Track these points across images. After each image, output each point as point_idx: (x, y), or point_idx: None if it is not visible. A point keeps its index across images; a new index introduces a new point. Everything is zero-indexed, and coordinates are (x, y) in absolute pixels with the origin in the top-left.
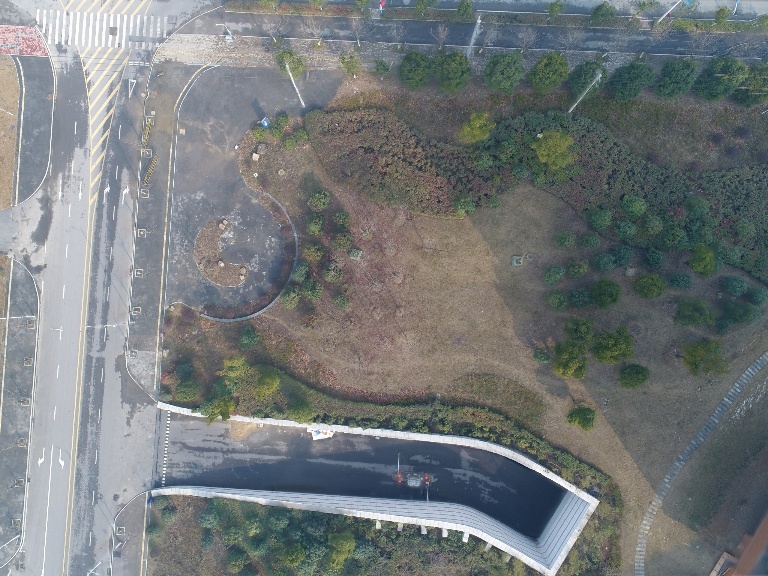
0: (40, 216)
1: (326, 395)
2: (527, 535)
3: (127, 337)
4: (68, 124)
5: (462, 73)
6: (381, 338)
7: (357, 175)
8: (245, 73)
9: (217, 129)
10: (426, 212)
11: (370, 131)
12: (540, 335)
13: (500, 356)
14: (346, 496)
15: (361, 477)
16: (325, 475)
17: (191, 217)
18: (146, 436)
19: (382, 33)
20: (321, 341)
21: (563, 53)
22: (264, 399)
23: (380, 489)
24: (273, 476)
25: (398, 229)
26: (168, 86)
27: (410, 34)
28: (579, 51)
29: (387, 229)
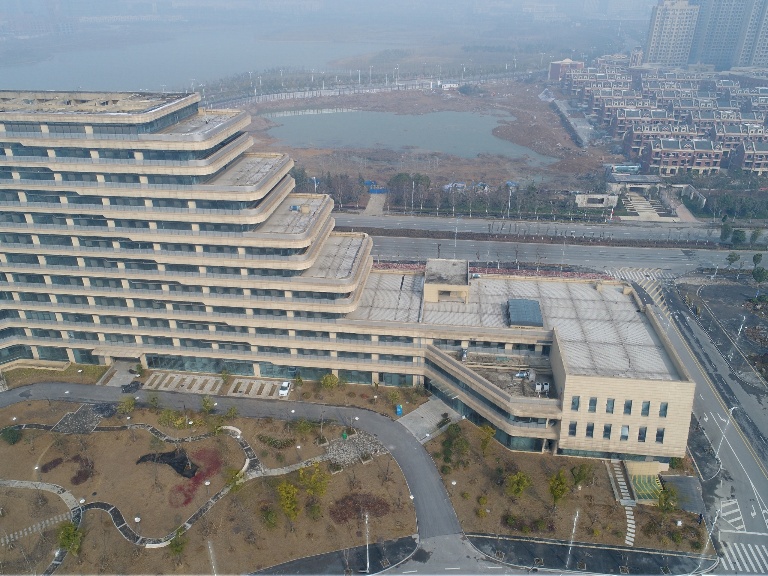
0: None
1: None
2: None
3: (729, 366)
4: None
5: None
6: None
7: None
8: None
9: None
10: None
11: None
12: None
13: None
14: None
15: None
16: None
17: None
18: None
19: None
20: None
21: None
22: None
23: None
24: None
25: None
26: None
27: None
28: None
29: None
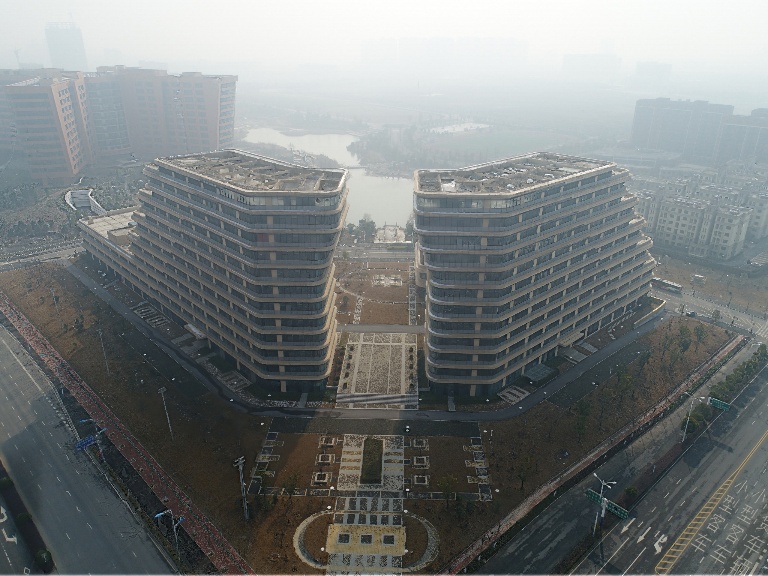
0: None
1: None
2: None
3: None
4: None
5: None
6: None
7: None
8: None
9: None
10: None
11: None
12: None
13: None
14: None
15: None
16: None
17: None
18: None
19: None
20: None
21: None
22: None
23: None
24: None
25: None
26: None
27: None
28: None
29: None
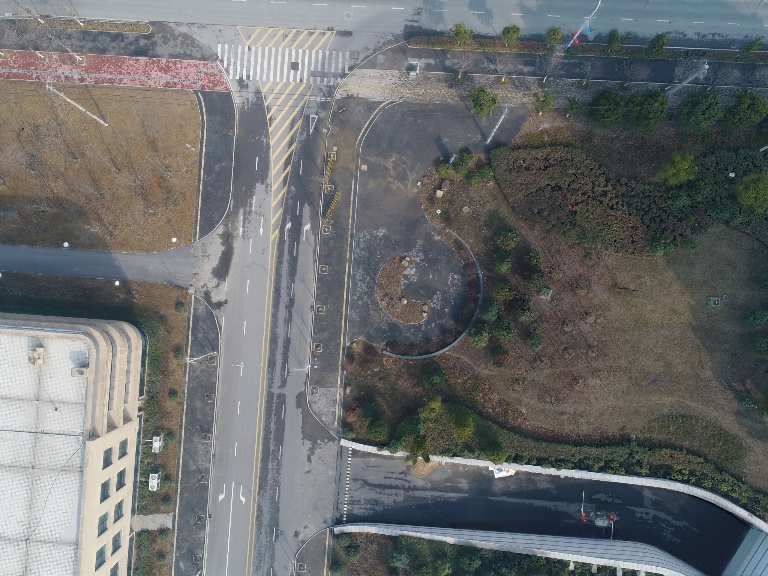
0: (221, 252)
1: (518, 435)
2: (709, 574)
3: (308, 373)
4: (249, 159)
5: (661, 113)
6: (573, 378)
7: (545, 213)
8: (428, 109)
9: (399, 165)
10: (620, 252)
11: (557, 169)
12: (739, 377)
13: (698, 398)
14: (528, 534)
15: (543, 515)
16: (507, 513)
17: (373, 253)
18: (327, 473)
19: (566, 69)
20: (509, 380)
21: (750, 90)
22: (453, 438)
23: (562, 527)
24: (454, 514)
25: (589, 268)
26: (350, 122)
27: (595, 70)
28: (766, 88)
29: (578, 268)
